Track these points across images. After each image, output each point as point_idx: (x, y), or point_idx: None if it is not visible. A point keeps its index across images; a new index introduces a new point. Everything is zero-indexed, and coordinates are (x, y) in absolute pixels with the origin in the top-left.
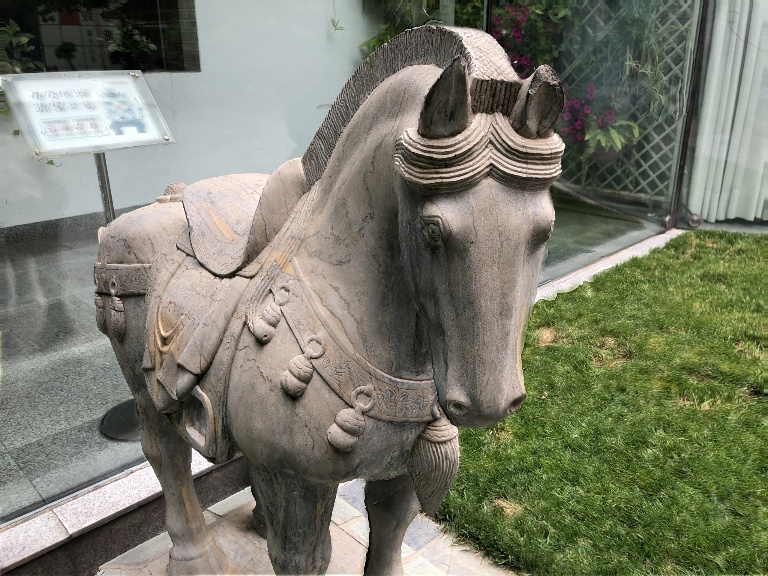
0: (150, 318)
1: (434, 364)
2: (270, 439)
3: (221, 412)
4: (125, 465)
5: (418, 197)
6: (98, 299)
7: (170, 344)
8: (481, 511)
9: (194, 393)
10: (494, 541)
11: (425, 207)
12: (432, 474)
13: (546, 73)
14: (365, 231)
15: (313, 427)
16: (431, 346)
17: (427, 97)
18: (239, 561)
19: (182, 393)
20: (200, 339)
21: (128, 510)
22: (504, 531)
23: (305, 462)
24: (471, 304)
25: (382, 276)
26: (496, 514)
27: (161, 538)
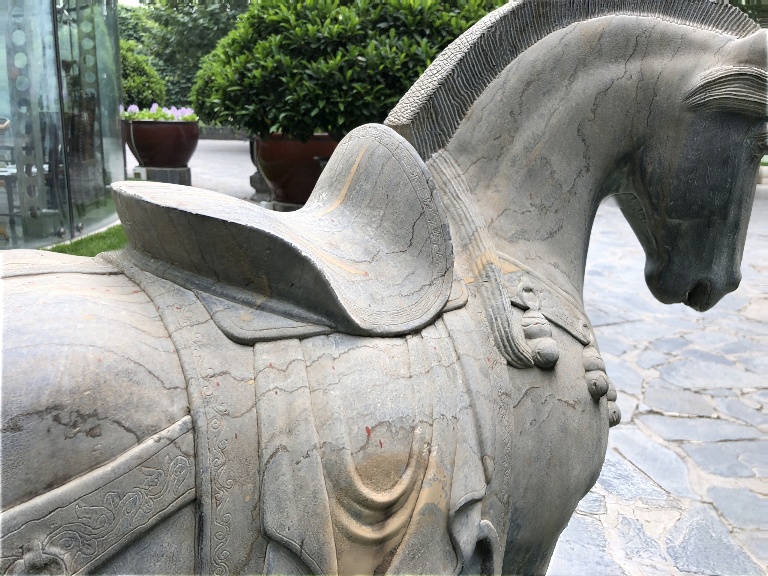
0: (314, 508)
1: None
2: None
3: None
4: None
5: (752, 121)
6: None
7: (412, 500)
8: None
9: None
10: None
11: (765, 127)
12: None
13: None
14: (577, 188)
15: (607, 419)
16: (715, 248)
17: None
18: None
19: None
20: (473, 434)
21: None
22: None
23: None
24: None
25: None
26: None
27: None
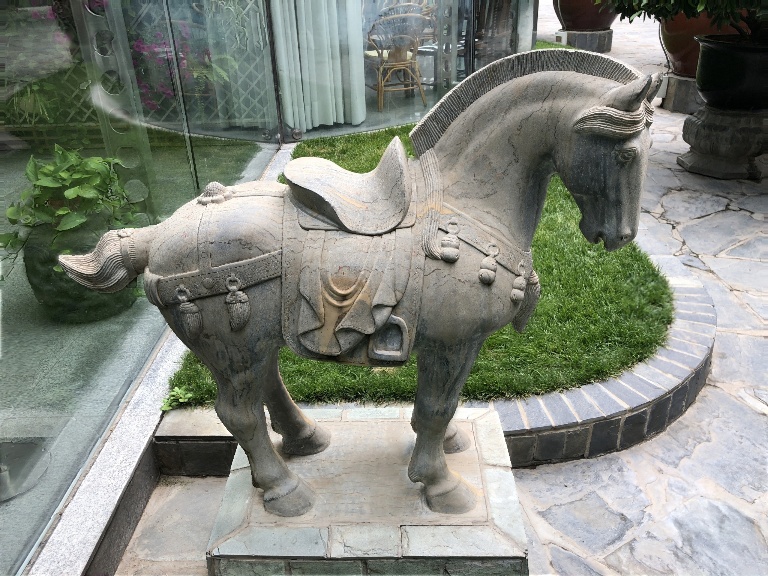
0: (315, 288)
1: (606, 223)
2: (473, 318)
3: (416, 323)
4: (46, 513)
5: (617, 141)
6: (192, 305)
7: (355, 297)
8: (376, 378)
9: (390, 321)
10: (403, 388)
11: (626, 144)
12: (533, 303)
13: (661, 75)
14: (509, 171)
15: (503, 296)
16: (605, 214)
17: (640, 93)
18: (311, 476)
19: (383, 324)
20: (391, 280)
21: (101, 539)
22: (402, 381)
23: (497, 321)
24: (639, 185)
25: (521, 195)
26: (384, 376)
27: (227, 505)
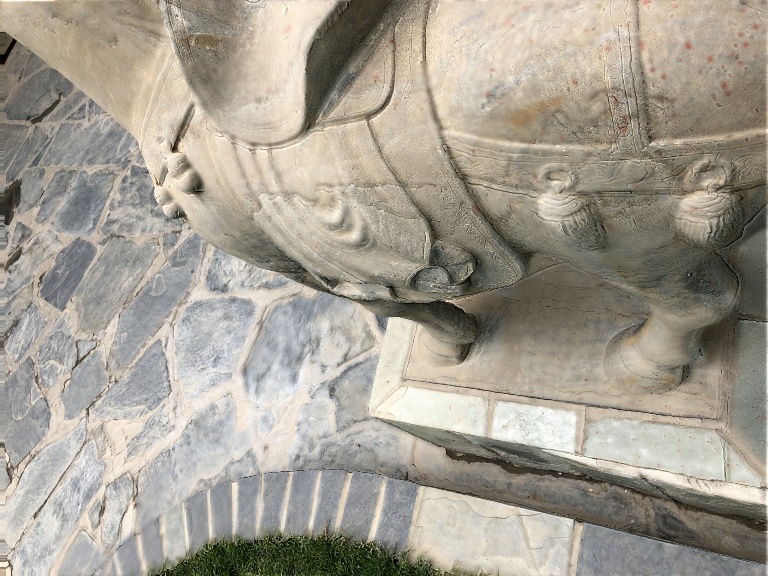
0: None
1: None
2: None
3: None
4: None
5: None
6: None
7: None
8: None
9: None
10: None
11: None
12: None
13: None
14: None
15: None
16: None
17: None
18: None
19: None
20: None
21: None
22: None
23: None
24: None
25: None
26: None
27: None
